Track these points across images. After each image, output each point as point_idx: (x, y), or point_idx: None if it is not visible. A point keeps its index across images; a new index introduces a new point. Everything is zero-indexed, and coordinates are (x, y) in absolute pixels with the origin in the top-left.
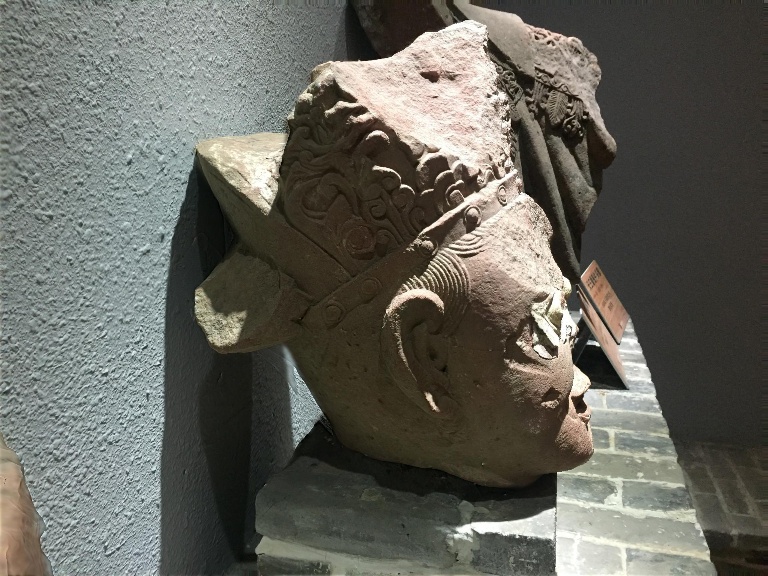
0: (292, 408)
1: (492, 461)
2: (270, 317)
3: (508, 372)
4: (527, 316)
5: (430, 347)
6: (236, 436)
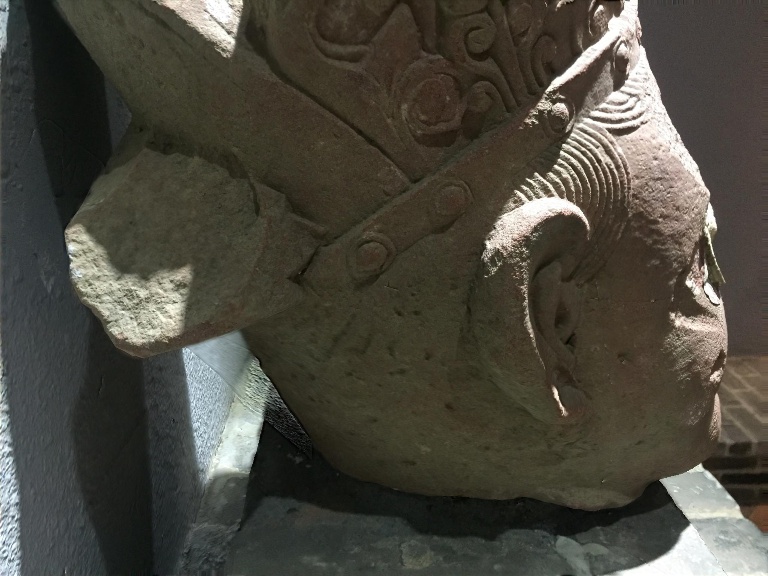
0: (191, 402)
1: (618, 475)
2: (248, 275)
3: (673, 334)
4: (700, 236)
5: (560, 305)
6: (132, 473)
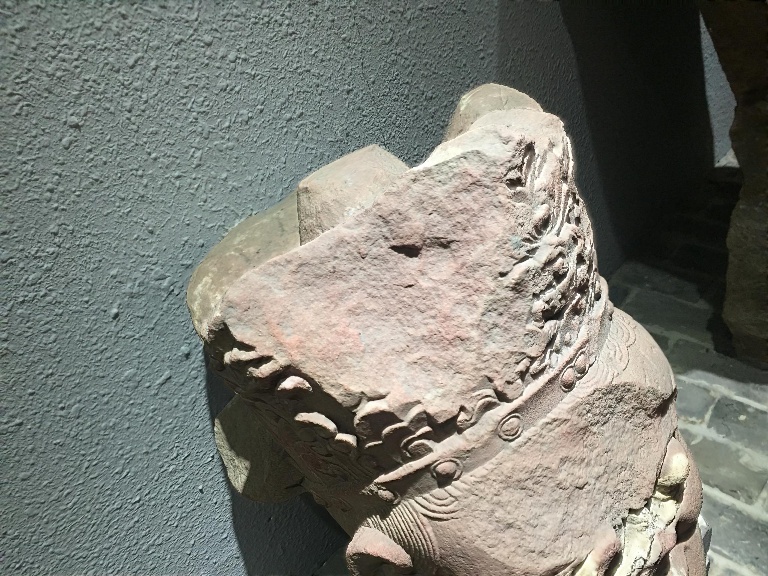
0: None
1: None
2: (263, 483)
3: None
4: None
5: None
6: None
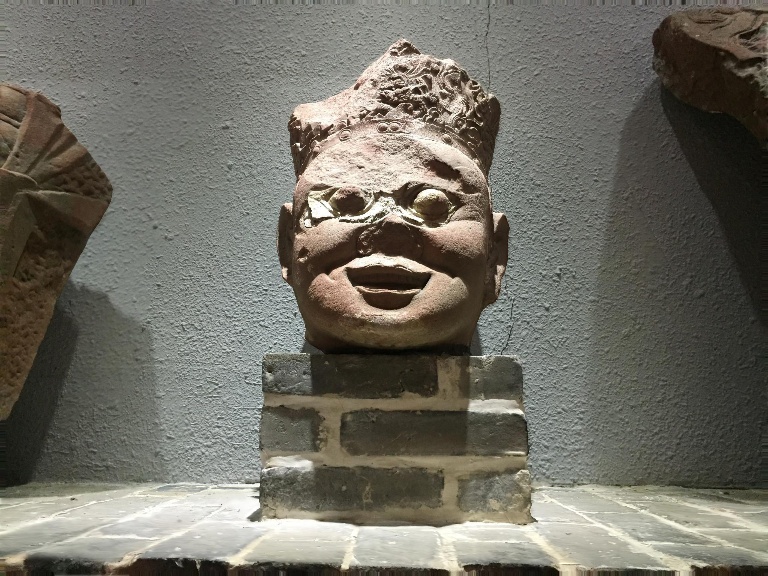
0: None
1: None
2: None
3: None
4: (306, 201)
5: None
6: None
